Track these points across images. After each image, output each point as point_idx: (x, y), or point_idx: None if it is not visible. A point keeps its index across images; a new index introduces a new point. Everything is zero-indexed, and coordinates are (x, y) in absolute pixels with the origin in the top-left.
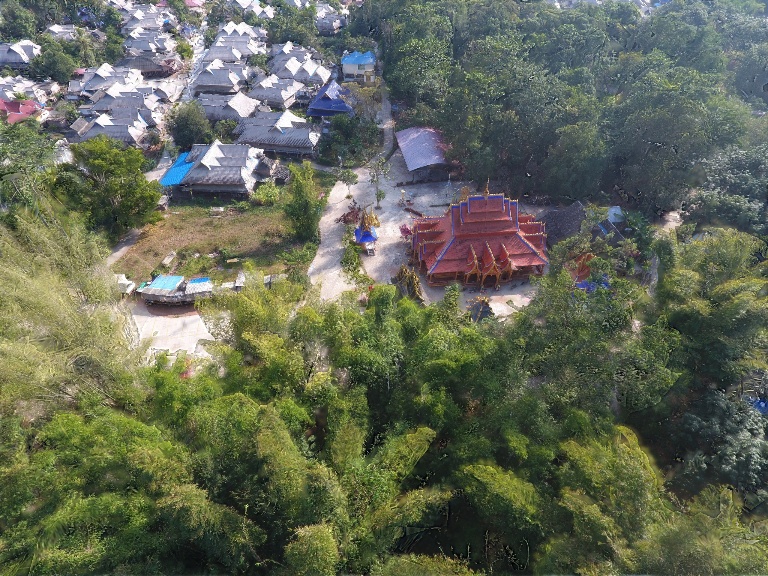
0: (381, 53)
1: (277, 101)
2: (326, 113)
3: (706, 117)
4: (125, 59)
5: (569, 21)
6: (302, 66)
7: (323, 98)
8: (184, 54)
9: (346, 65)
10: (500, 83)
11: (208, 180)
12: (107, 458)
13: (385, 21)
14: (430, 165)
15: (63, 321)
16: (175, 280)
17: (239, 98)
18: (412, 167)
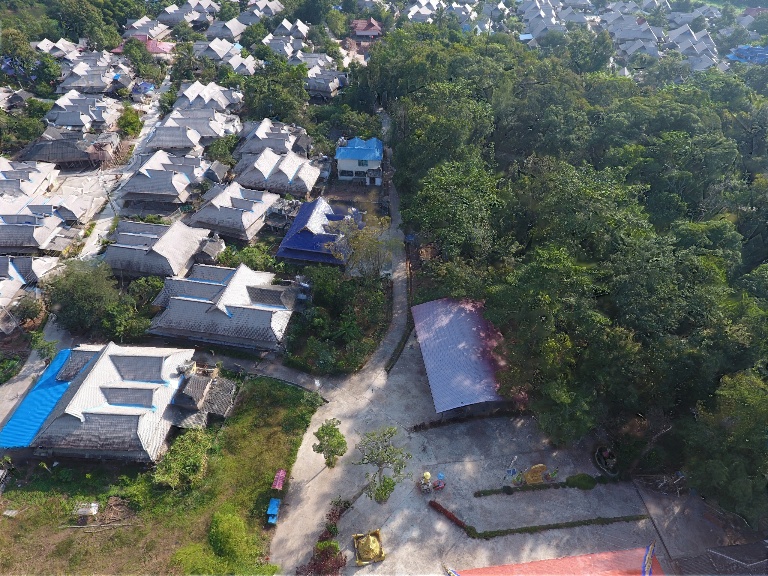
0: (391, 139)
1: (236, 227)
2: (306, 254)
3: None
4: (37, 145)
5: (673, 120)
6: (278, 167)
7: (302, 232)
8: (128, 129)
9: (342, 160)
10: (582, 237)
11: (78, 442)
12: None
13: (397, 99)
14: (473, 401)
15: None
16: None
17: (174, 233)
18: (441, 403)
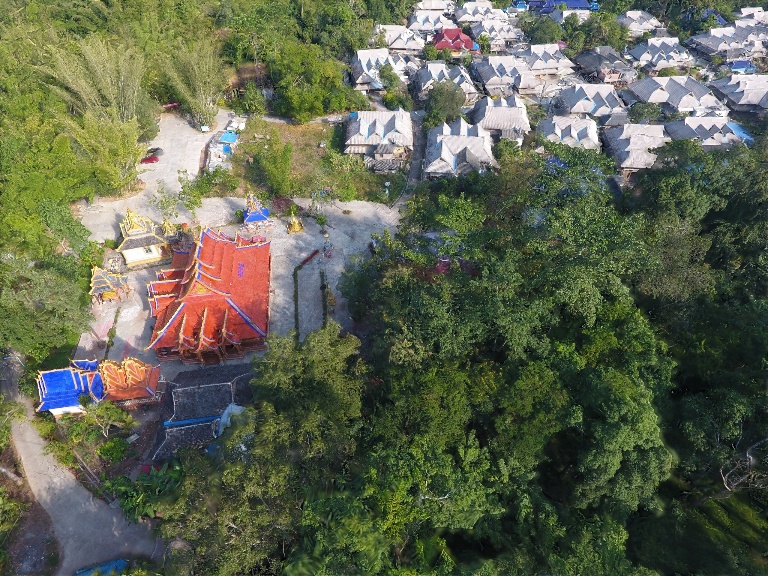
0: None
1: None
2: None
3: (243, 569)
4: (589, 52)
5: None
6: None
7: None
8: None
9: None
10: None
11: None
12: (0, 98)
13: None
14: None
15: (95, 72)
16: (230, 140)
17: (509, 111)
18: None
